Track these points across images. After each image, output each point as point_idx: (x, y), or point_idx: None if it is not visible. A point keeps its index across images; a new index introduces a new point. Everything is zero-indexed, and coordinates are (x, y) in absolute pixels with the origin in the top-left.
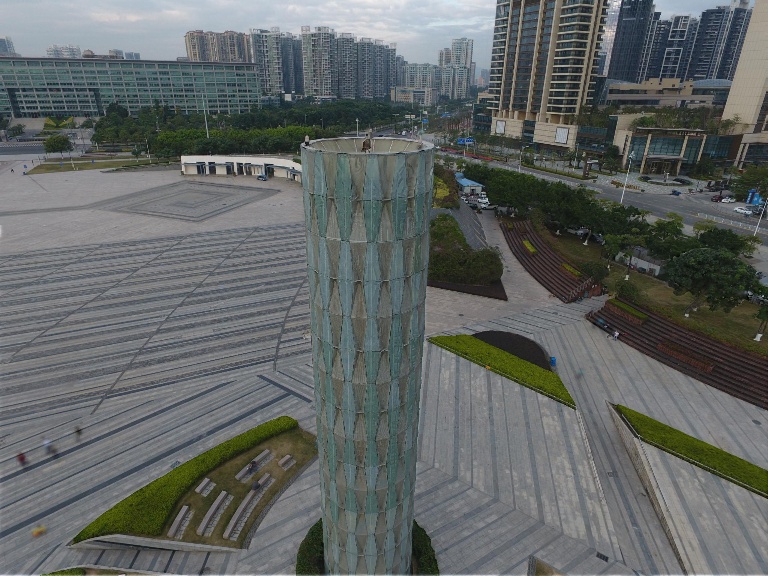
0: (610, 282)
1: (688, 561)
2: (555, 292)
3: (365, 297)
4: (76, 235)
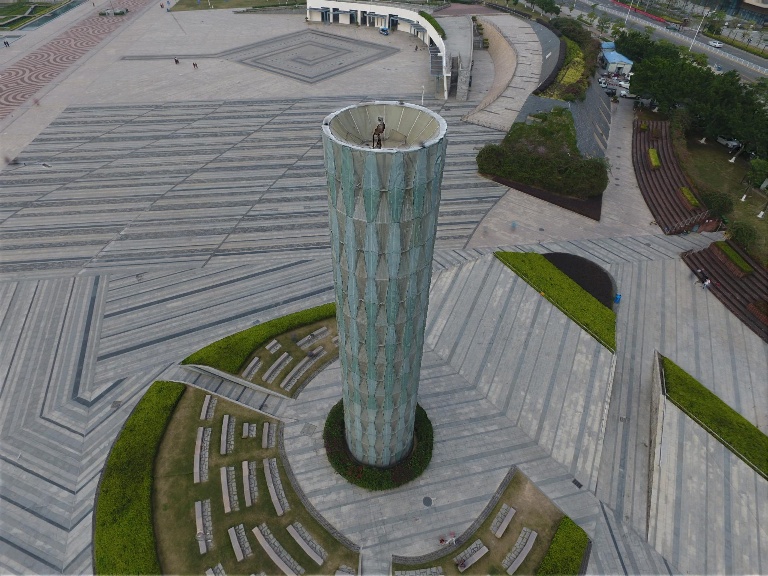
0: (736, 216)
1: (656, 510)
2: (659, 219)
3: (366, 263)
4: (205, 88)
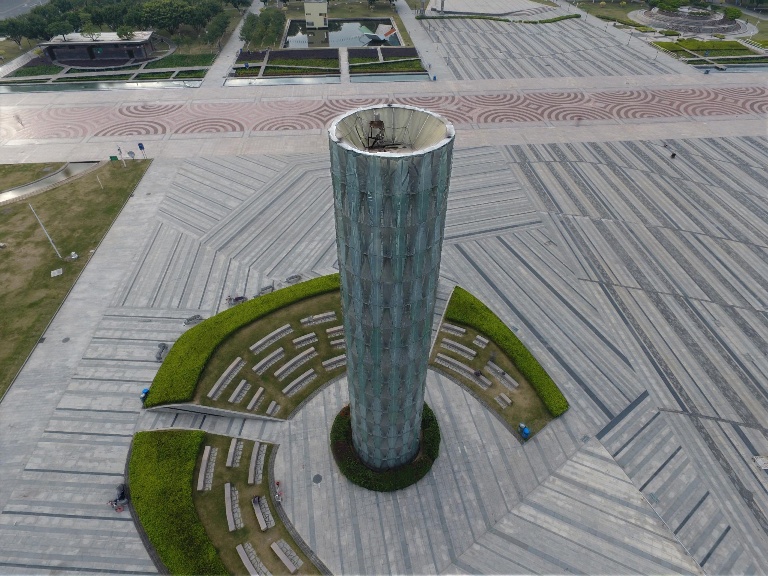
0: None
1: None
2: None
3: None
4: None
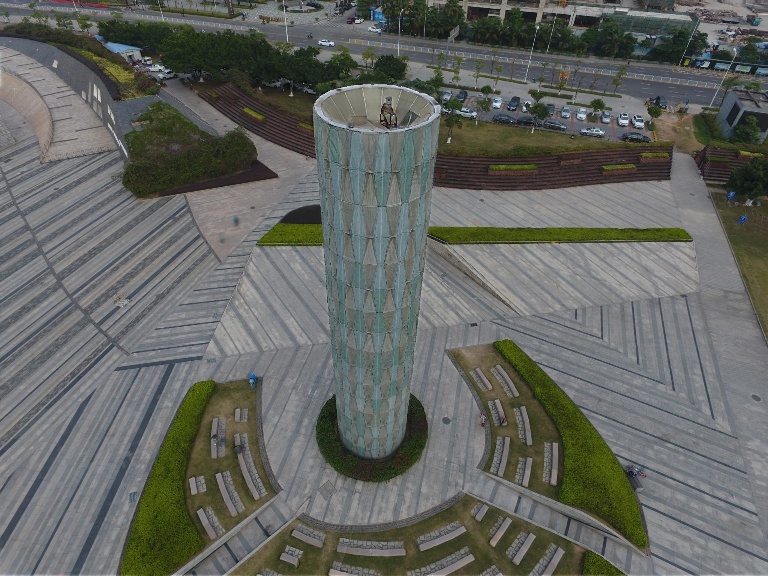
0: None
1: (507, 299)
2: (308, 153)
3: (415, 240)
4: None
